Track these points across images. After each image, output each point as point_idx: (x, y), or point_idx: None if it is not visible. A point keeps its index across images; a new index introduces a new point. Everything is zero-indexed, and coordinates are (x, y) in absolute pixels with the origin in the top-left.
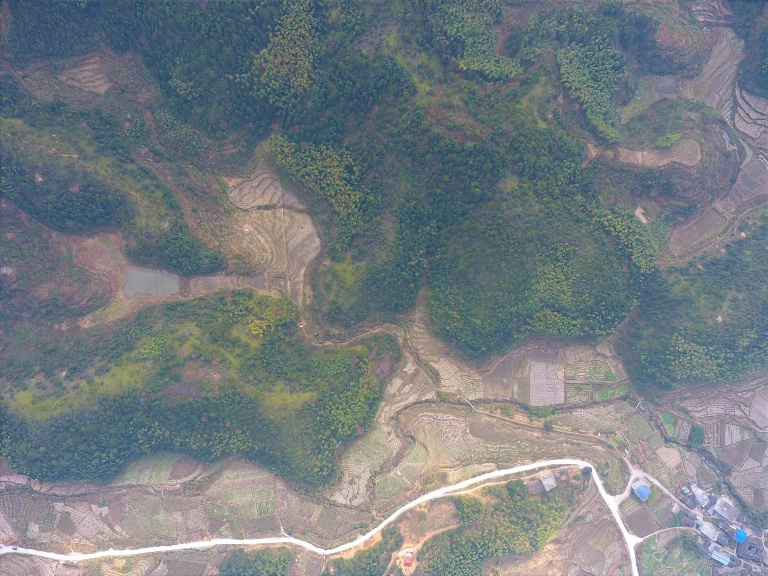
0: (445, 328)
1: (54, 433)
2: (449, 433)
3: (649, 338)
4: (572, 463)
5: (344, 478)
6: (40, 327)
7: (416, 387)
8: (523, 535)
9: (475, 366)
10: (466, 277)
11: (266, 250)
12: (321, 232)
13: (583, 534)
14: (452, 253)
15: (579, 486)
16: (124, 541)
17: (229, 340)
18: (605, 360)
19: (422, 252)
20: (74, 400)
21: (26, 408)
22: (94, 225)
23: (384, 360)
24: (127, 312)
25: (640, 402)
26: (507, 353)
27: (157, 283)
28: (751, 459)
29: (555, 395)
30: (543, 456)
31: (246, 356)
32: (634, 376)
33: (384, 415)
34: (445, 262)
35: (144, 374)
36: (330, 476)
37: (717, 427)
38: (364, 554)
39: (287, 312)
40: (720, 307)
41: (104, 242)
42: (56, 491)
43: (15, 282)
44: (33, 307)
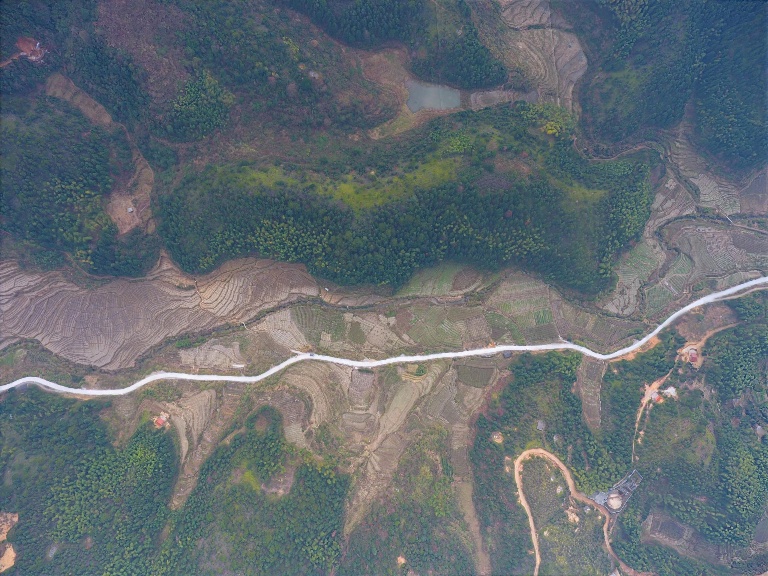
0: (713, 138)
1: (376, 222)
2: (713, 244)
3: None
4: None
5: None
6: (336, 137)
7: (678, 202)
8: None
9: (735, 179)
10: (749, 76)
11: (539, 66)
12: (588, 50)
13: None
14: (734, 55)
15: None
16: (413, 348)
17: (531, 137)
18: None
19: (705, 54)
20: (392, 192)
21: (351, 197)
22: (383, 39)
23: (655, 170)
24: (414, 124)
25: None
26: (763, 168)
27: (439, 98)
28: None
29: None
30: None
31: (549, 151)
32: None
33: (648, 229)
34: (727, 63)
35: (457, 167)
36: (606, 284)
37: None
38: (649, 353)
39: (571, 119)
40: None
41: (389, 58)
42: (345, 302)
43: (323, 85)
44: (334, 114)
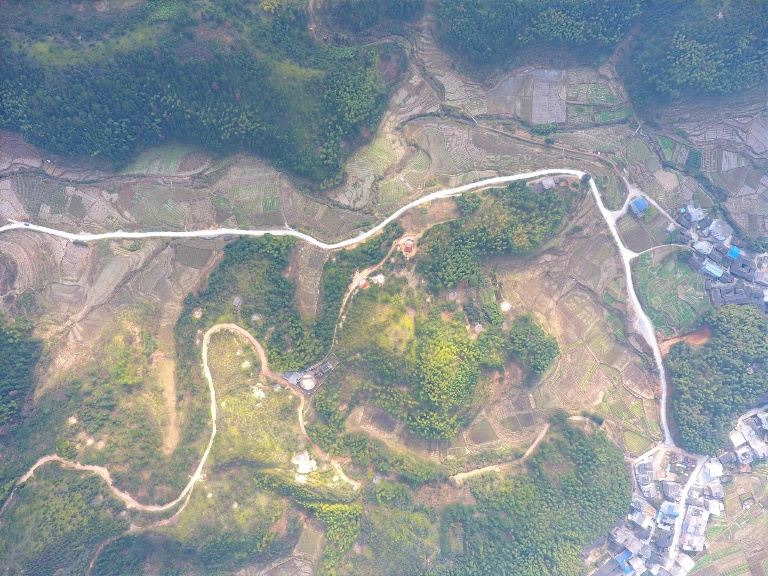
0: (451, 32)
1: (70, 83)
2: (452, 142)
3: (651, 46)
4: (571, 173)
5: (348, 181)
6: (58, 5)
7: (421, 98)
8: (522, 226)
9: (479, 78)
10: None
11: None
12: None
13: (580, 248)
14: None
15: (578, 193)
16: (133, 225)
17: (242, 10)
18: (607, 83)
19: None
20: (90, 54)
21: (44, 55)
22: None
23: (391, 62)
24: None
25: (640, 126)
26: (511, 70)
27: None
28: (747, 186)
29: (557, 114)
30: (543, 166)
31: (258, 24)
32: (635, 93)
33: (389, 124)
34: None
35: (158, 33)
36: (335, 173)
37: (714, 153)
38: (366, 242)
39: (298, 1)
40: (721, 5)
41: None
42: (68, 176)
43: None
44: None
